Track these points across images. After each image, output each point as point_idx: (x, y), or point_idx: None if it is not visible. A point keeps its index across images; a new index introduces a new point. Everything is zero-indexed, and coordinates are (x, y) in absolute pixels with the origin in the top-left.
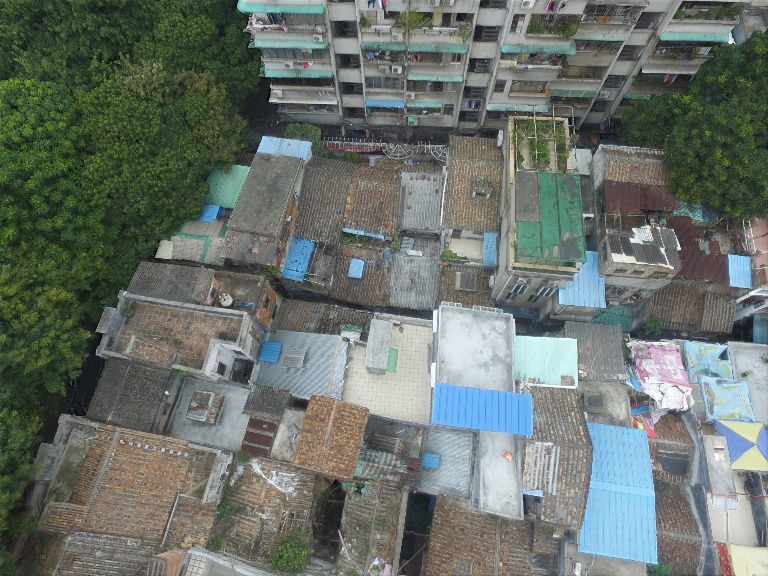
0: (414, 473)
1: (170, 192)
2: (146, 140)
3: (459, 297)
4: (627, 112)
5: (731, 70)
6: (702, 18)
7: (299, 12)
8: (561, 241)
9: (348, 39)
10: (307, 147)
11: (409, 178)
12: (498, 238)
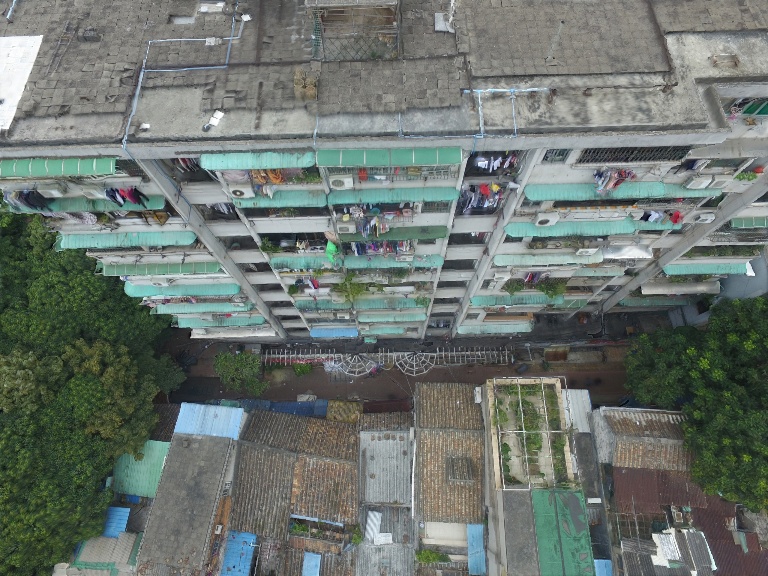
0: None
1: (56, 526)
2: (13, 479)
3: None
4: (631, 364)
5: (758, 332)
6: (714, 254)
7: (206, 294)
8: None
9: (278, 292)
10: (238, 418)
11: (369, 438)
12: (485, 535)
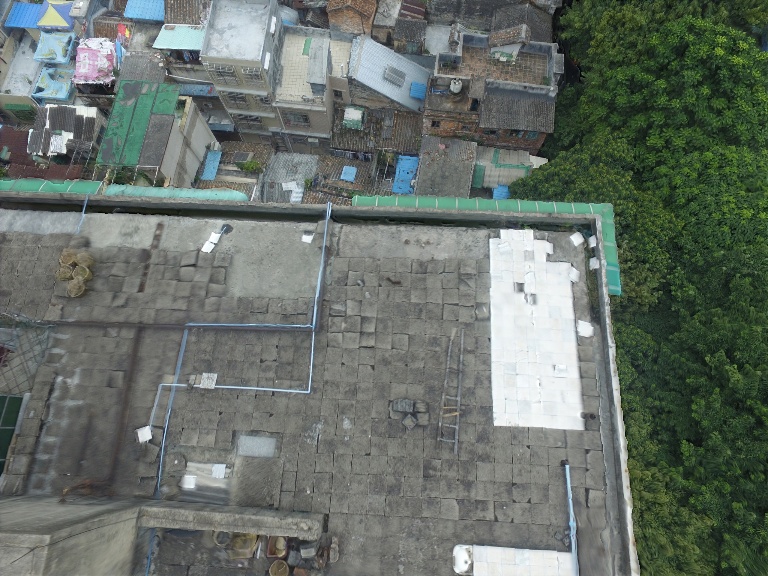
0: (298, 0)
1: None
2: None
3: (252, 150)
4: None
5: None
6: None
7: None
8: (137, 97)
9: None
10: None
11: None
12: (201, 171)
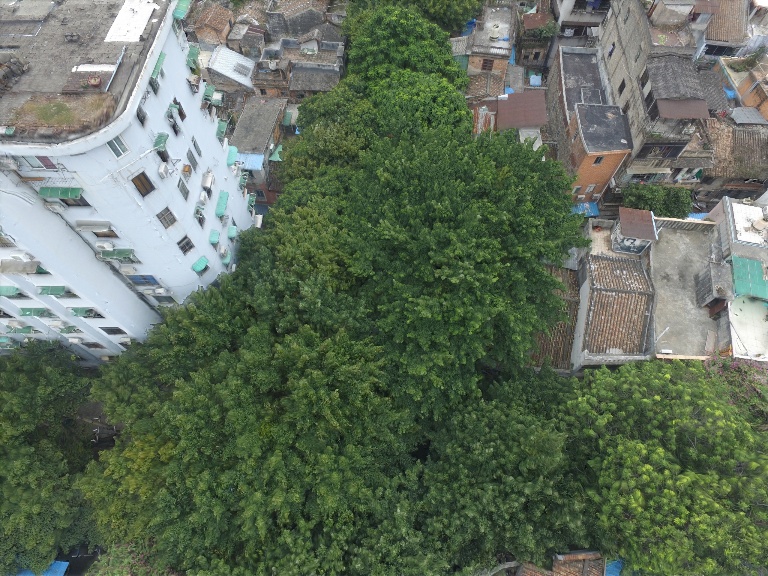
0: None
1: None
2: None
3: None
4: None
5: None
6: None
7: None
8: None
9: None
10: None
11: None
12: None
